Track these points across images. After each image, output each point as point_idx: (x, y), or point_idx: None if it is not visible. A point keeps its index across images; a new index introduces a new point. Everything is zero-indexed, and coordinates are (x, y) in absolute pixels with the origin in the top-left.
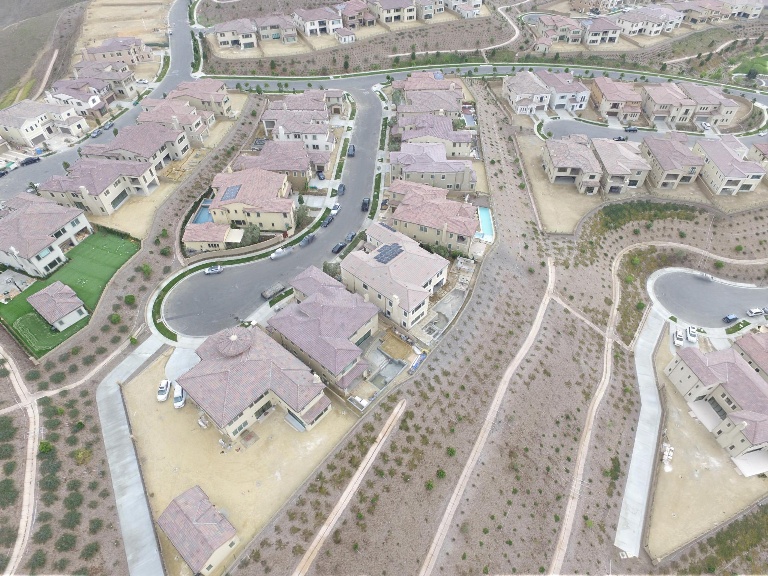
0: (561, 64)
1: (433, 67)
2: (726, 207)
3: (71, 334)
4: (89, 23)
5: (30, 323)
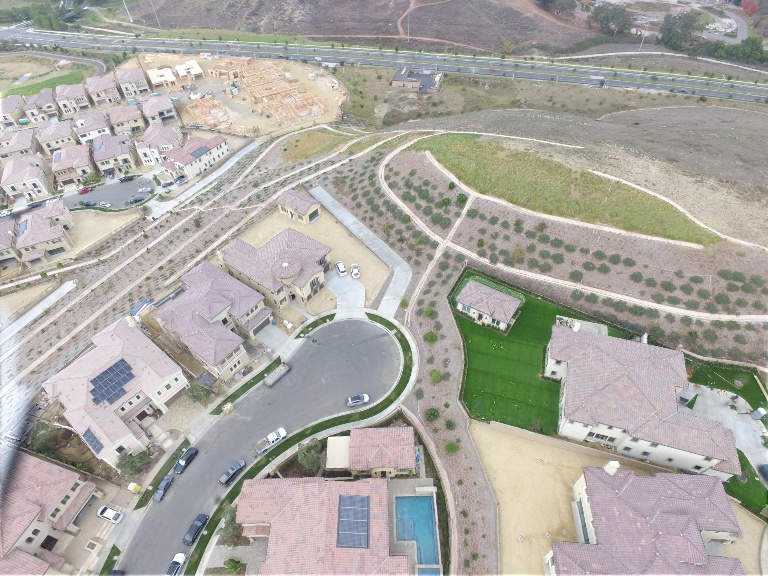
0: None
1: None
2: None
3: (458, 291)
4: None
5: None
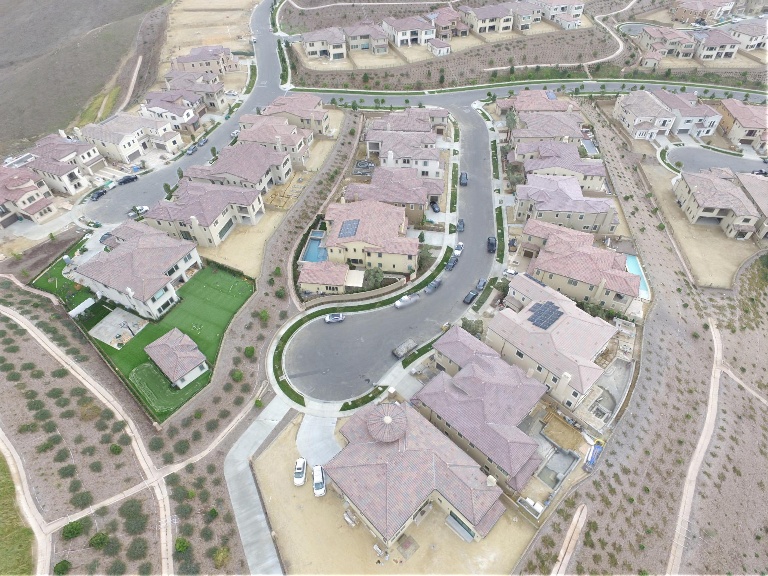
0: (672, 81)
1: (533, 82)
2: None
3: (192, 393)
4: (172, 29)
5: (147, 376)
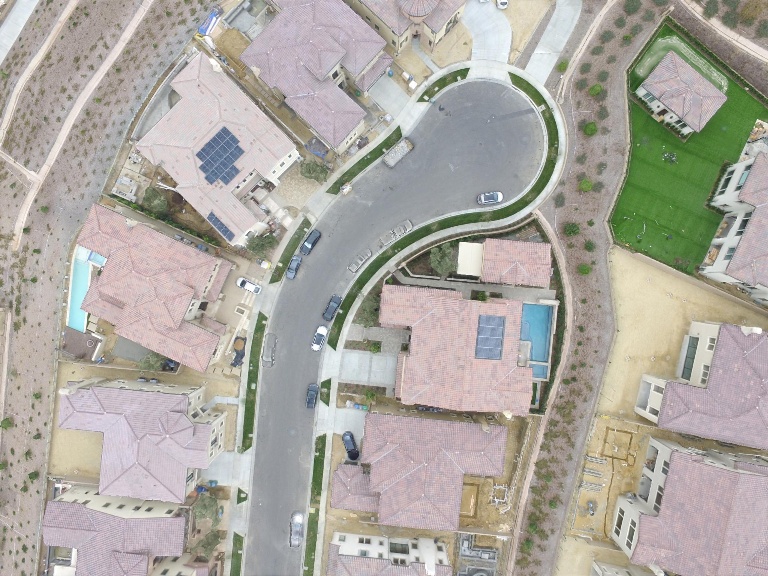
0: None
1: None
2: None
3: (643, 60)
4: None
5: None
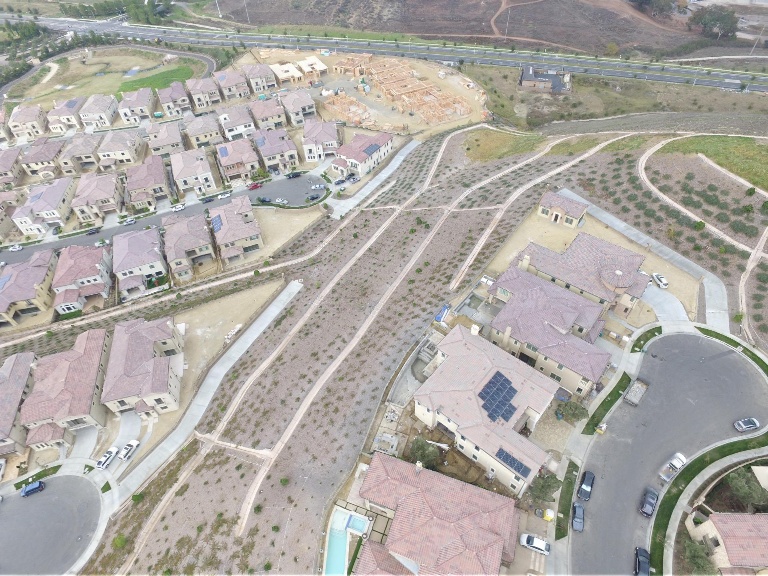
0: None
1: None
2: None
3: None
4: None
5: None
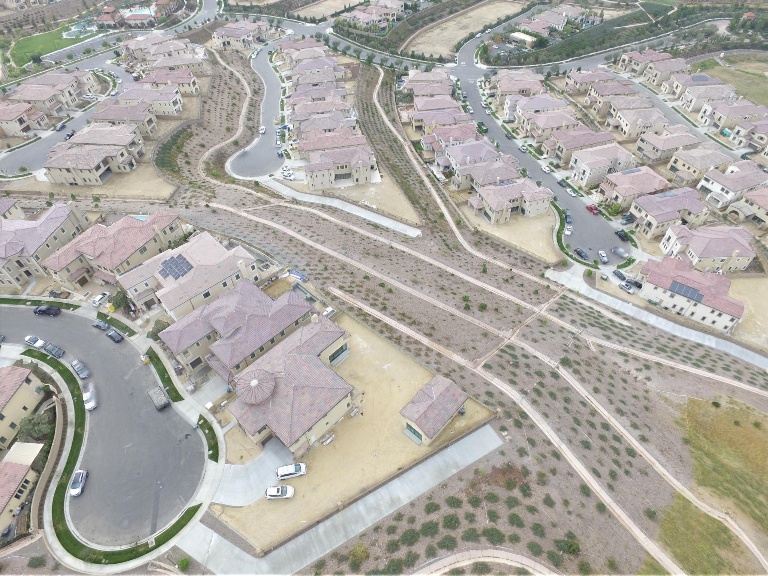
0: None
1: None
2: (193, 116)
3: None
4: None
5: None
